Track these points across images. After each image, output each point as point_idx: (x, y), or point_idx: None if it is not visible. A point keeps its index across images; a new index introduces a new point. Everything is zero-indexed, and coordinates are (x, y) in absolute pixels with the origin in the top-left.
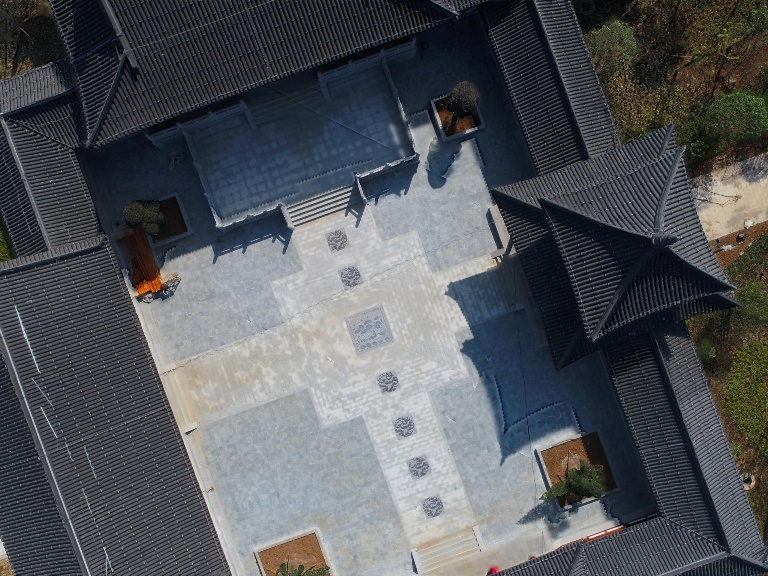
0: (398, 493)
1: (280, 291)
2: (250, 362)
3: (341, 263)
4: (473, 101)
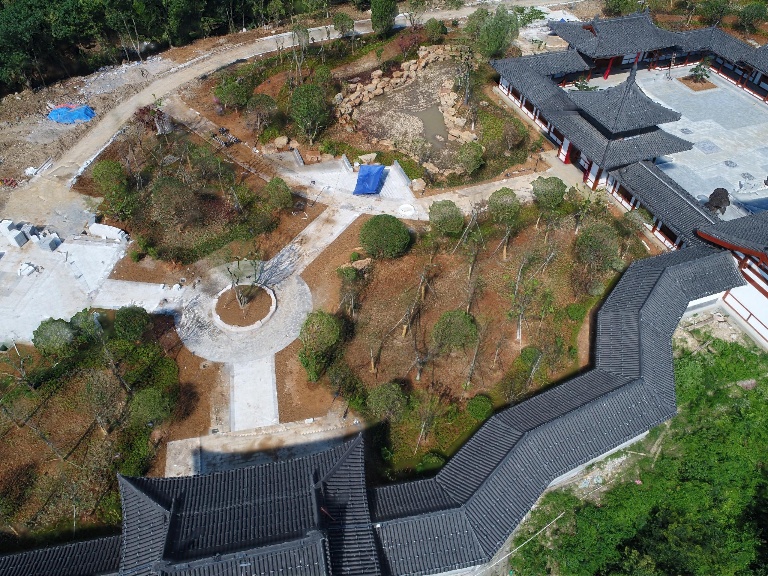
0: (660, 102)
1: (767, 160)
2: (765, 138)
3: (740, 169)
4: (718, 189)
